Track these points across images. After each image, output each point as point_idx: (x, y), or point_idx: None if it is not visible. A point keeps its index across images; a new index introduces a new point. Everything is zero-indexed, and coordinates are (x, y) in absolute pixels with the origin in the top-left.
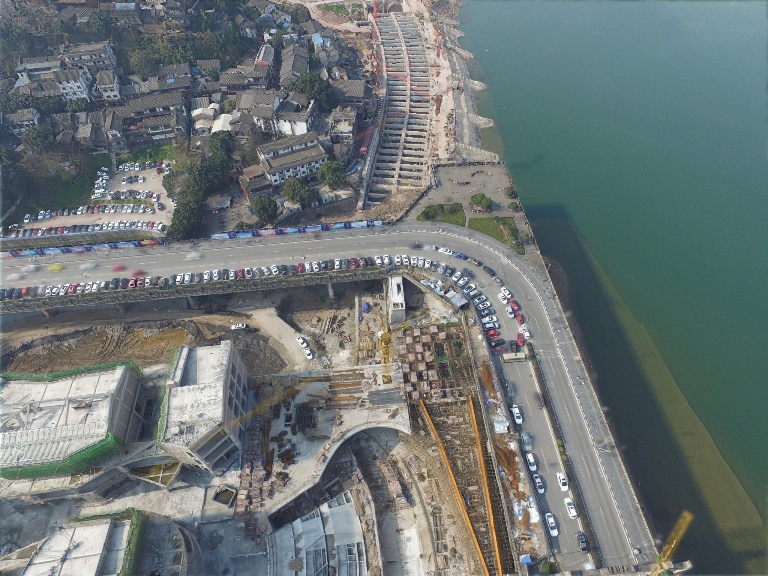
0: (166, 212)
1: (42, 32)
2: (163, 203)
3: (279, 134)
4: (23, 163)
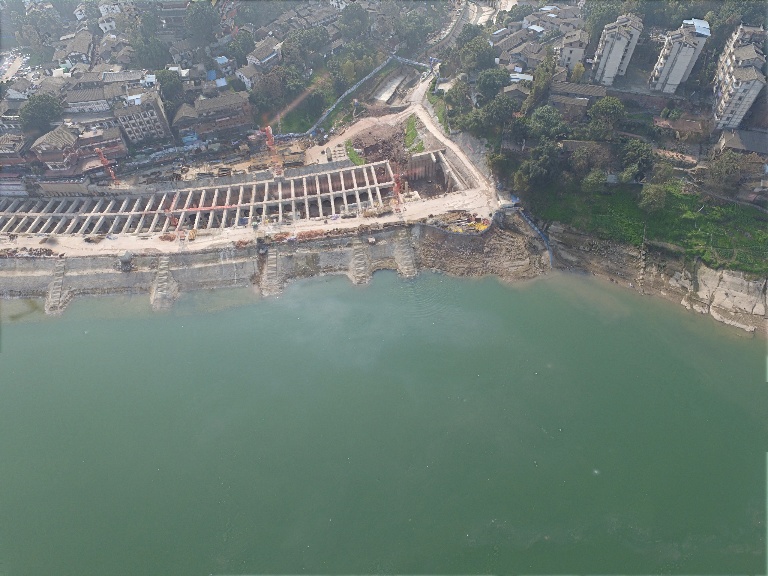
0: None
1: None
2: None
3: None
4: None
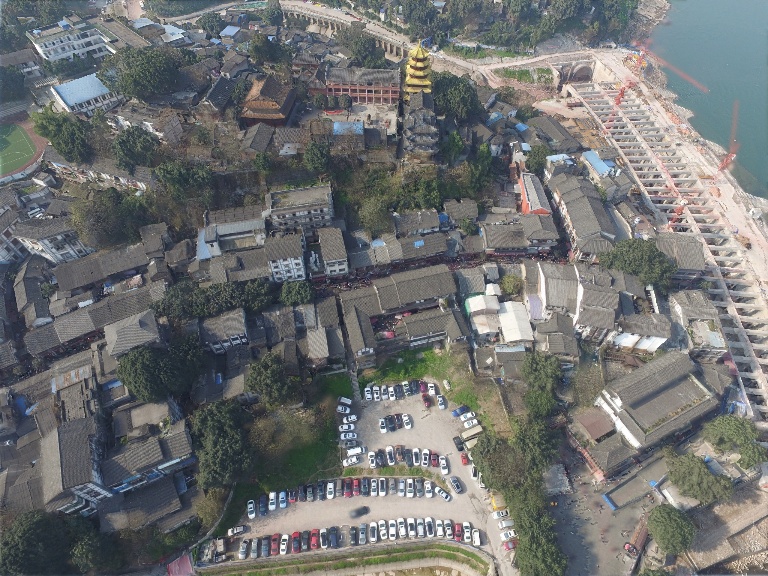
0: (469, 497)
1: (230, 169)
2: (458, 476)
3: (609, 345)
4: (258, 435)
